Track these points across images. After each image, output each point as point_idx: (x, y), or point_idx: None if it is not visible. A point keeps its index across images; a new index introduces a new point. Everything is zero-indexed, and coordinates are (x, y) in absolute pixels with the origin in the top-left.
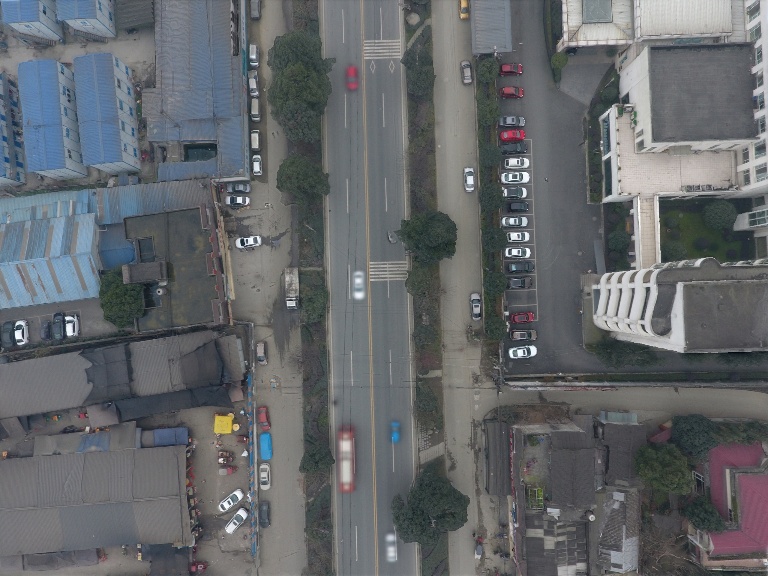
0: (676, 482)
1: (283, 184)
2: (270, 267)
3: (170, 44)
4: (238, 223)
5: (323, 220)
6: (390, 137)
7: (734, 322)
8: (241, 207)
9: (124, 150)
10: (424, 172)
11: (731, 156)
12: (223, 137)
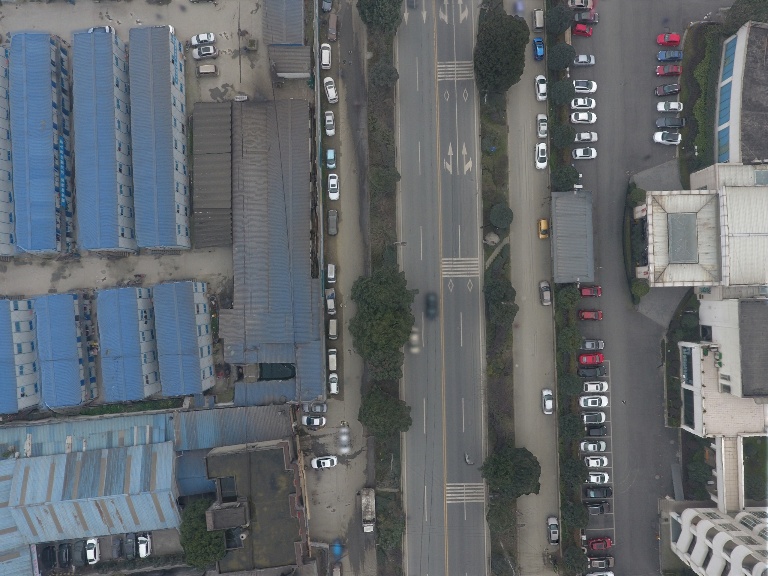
0: None
1: (368, 426)
2: (345, 486)
3: (248, 264)
4: (313, 441)
5: (400, 440)
6: (468, 357)
7: None
8: (318, 428)
9: (203, 377)
10: (502, 395)
11: None
12: (302, 362)
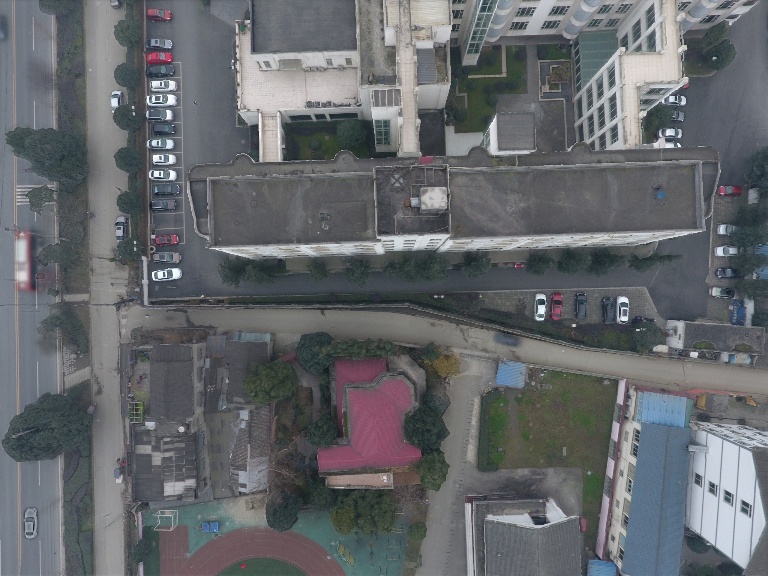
0: (254, 390)
1: None
2: None
3: None
4: None
5: None
6: (40, 61)
7: (268, 219)
8: None
9: None
10: (69, 95)
11: (356, 73)
12: None
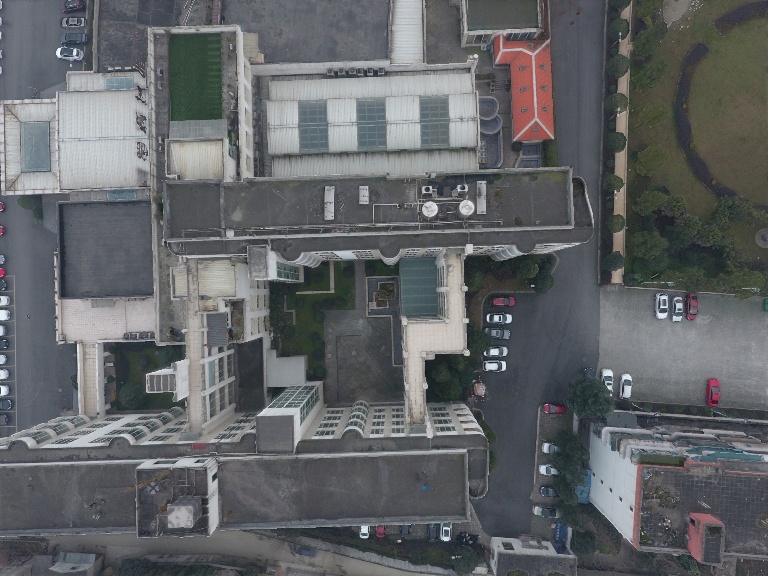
0: None
1: None
2: None
3: None
4: None
5: None
6: None
7: (44, 503)
8: None
9: None
10: None
11: None
12: None
